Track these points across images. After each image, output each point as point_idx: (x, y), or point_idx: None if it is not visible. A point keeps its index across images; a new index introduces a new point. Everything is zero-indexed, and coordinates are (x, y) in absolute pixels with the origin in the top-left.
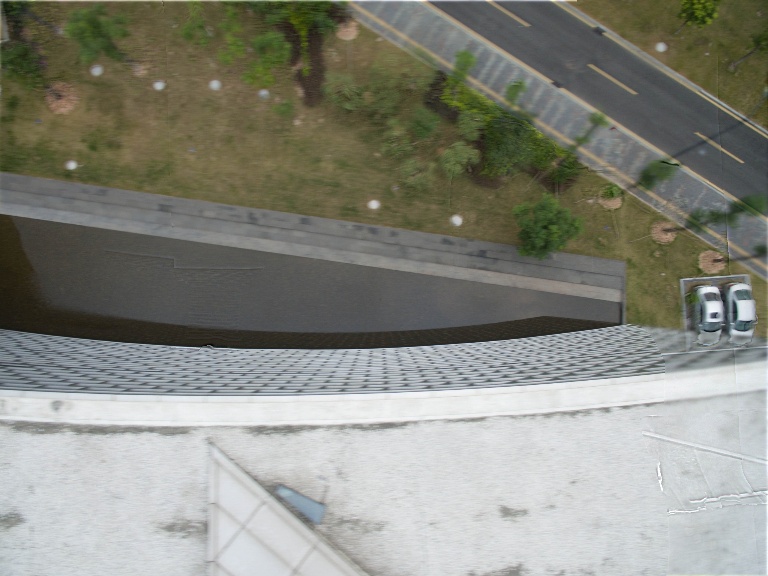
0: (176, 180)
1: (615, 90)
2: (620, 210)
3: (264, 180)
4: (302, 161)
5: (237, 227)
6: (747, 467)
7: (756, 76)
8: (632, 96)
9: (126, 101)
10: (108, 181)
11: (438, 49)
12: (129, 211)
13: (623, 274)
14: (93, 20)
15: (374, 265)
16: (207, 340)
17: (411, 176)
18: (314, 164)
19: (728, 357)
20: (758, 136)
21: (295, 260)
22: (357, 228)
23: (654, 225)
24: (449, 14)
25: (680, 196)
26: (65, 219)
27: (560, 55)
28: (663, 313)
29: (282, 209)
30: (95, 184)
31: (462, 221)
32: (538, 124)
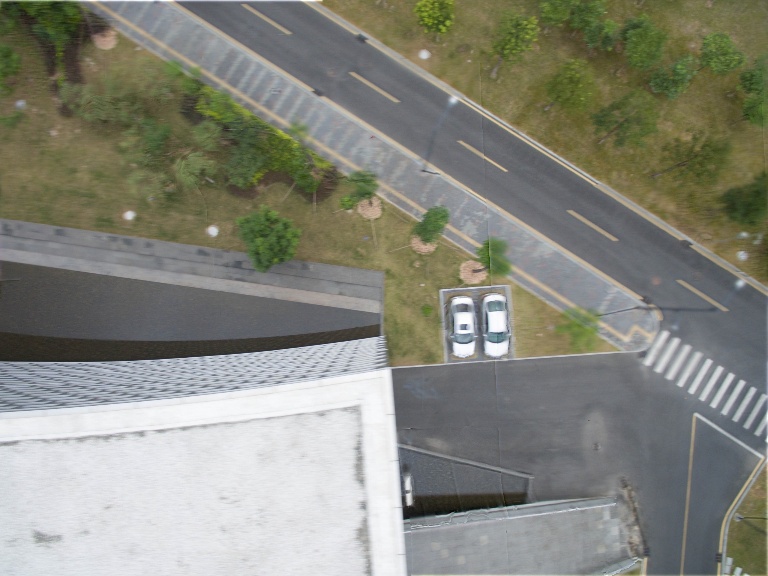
0: None
1: (376, 98)
2: (380, 220)
3: (19, 191)
4: (58, 172)
5: None
6: (506, 480)
7: (519, 83)
8: (394, 104)
9: None
10: None
11: (197, 58)
12: None
13: (381, 285)
14: None
15: (130, 276)
16: None
17: (166, 187)
18: (70, 175)
19: (488, 369)
20: (522, 144)
21: (51, 271)
22: (112, 239)
23: (414, 235)
24: (209, 22)
25: (441, 205)
26: None
27: (321, 63)
28: (422, 324)
29: (37, 220)
30: None
31: (218, 232)
32: (297, 133)
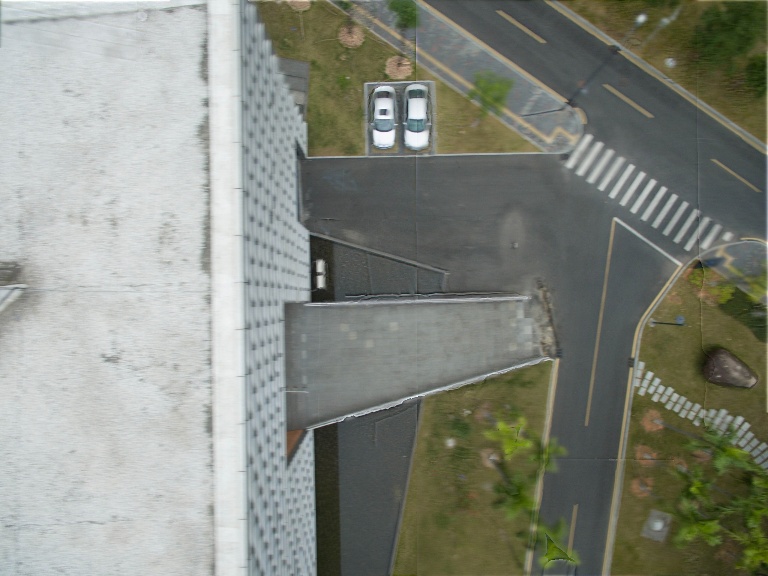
0: None
1: None
2: (309, 12)
3: None
4: None
5: None
6: (422, 275)
7: None
8: None
9: None
10: None
11: None
12: None
13: (306, 75)
14: None
15: None
16: None
17: None
18: None
19: (409, 164)
20: None
21: None
22: (42, 19)
23: (341, 28)
24: None
25: (370, 0)
26: None
27: None
28: (345, 116)
29: None
30: None
31: (147, 16)
32: None
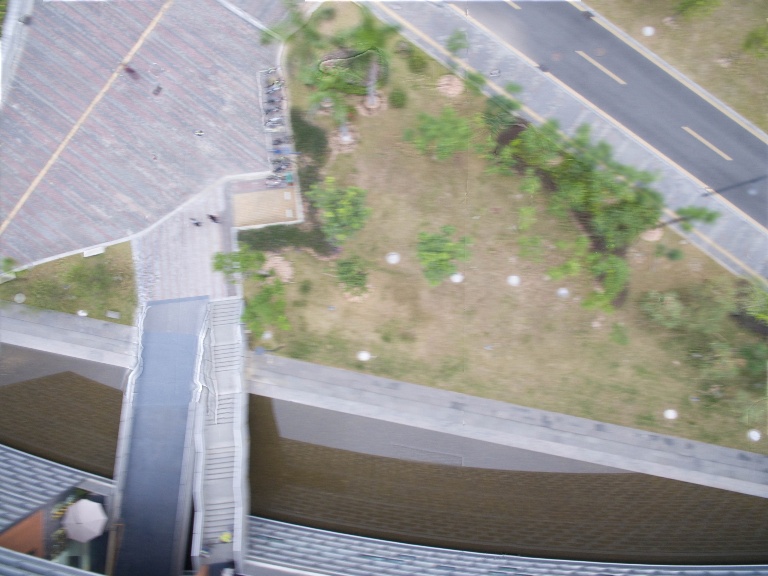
0: (470, 378)
1: None
2: None
3: (560, 383)
4: (599, 365)
5: (530, 429)
6: None
7: None
8: None
9: (422, 292)
10: (401, 375)
11: (742, 255)
12: (421, 406)
13: None
14: (391, 206)
15: (667, 476)
16: (499, 547)
17: (711, 388)
18: (611, 369)
19: None
20: None
21: (586, 466)
22: (653, 438)
23: None
24: (755, 219)
25: None
26: (353, 410)
27: None
28: None
29: (577, 414)
30: (388, 377)
31: (760, 436)
32: None
